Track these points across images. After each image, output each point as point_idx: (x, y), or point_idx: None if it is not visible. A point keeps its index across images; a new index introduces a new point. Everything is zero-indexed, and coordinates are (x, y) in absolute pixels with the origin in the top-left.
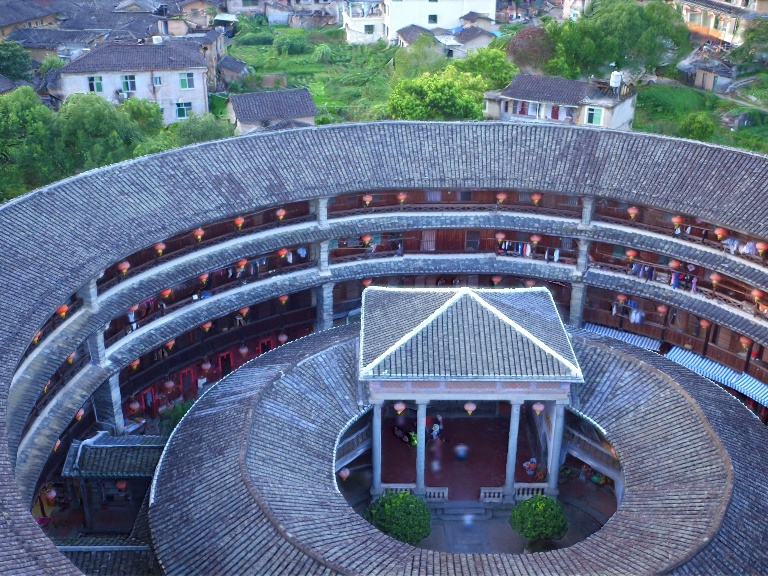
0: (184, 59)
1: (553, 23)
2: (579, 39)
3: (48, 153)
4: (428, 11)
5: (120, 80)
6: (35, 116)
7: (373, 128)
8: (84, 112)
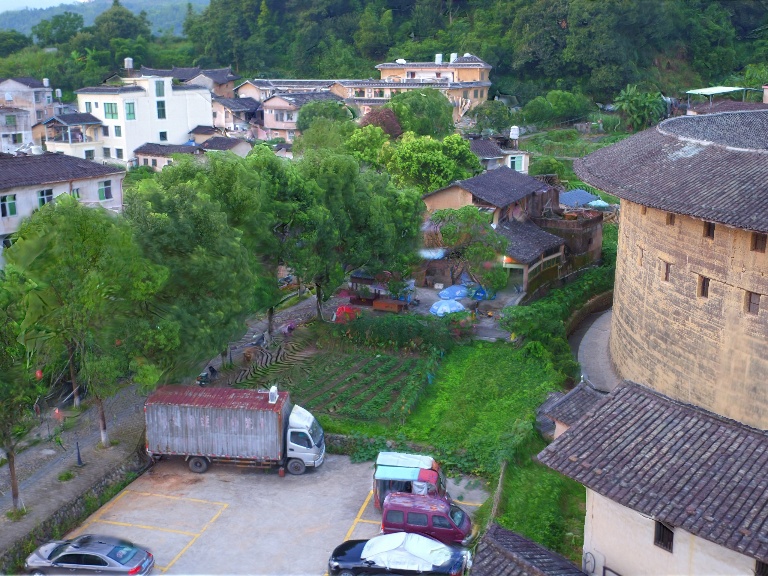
0: (95, 166)
1: (392, 105)
2: (409, 118)
3: (329, 215)
4: (159, 128)
5: (36, 197)
6: (299, 175)
7: (680, 122)
8: (352, 162)
